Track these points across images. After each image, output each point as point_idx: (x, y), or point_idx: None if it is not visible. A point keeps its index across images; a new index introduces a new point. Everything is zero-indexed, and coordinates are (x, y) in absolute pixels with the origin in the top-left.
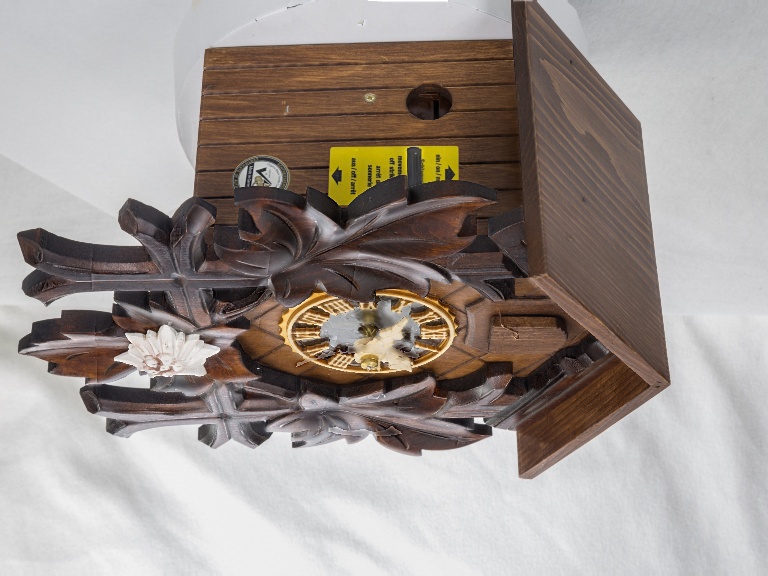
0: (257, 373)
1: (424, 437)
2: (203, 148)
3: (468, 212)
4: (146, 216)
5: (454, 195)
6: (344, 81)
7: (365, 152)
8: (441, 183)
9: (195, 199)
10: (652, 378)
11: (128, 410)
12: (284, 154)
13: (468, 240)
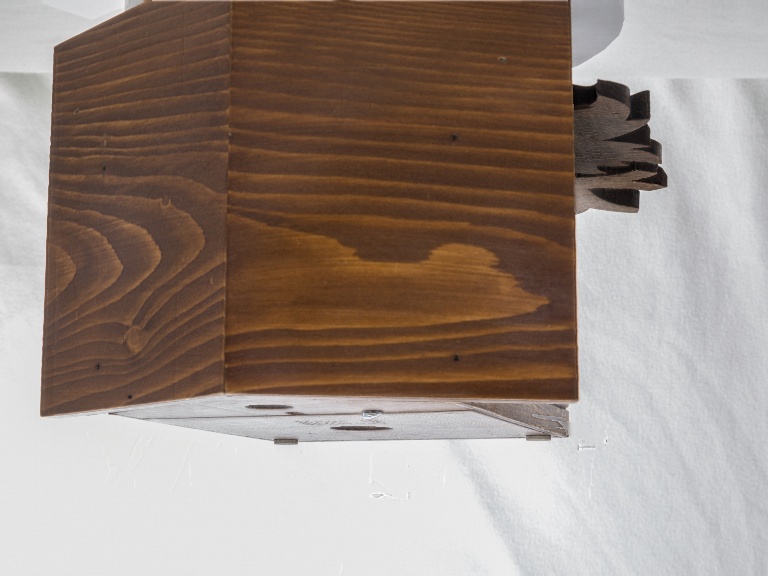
0: None
1: None
2: None
3: None
4: None
5: None
6: None
7: None
8: None
9: None
10: None
11: None
12: None
13: None
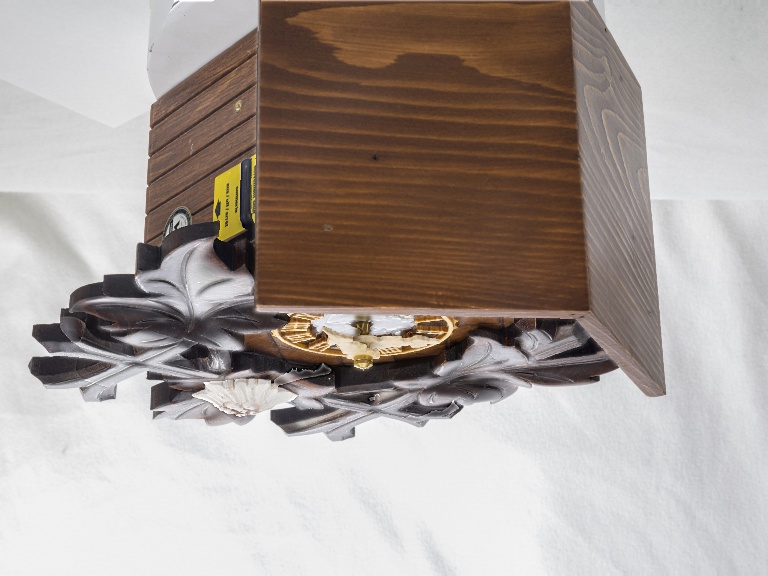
0: (329, 384)
1: (576, 367)
2: (147, 217)
3: (212, 251)
4: (49, 336)
5: (175, 248)
6: (224, 95)
7: (234, 173)
8: (168, 237)
9: (61, 312)
10: (558, 315)
11: (307, 427)
12: (189, 200)
13: (243, 271)
